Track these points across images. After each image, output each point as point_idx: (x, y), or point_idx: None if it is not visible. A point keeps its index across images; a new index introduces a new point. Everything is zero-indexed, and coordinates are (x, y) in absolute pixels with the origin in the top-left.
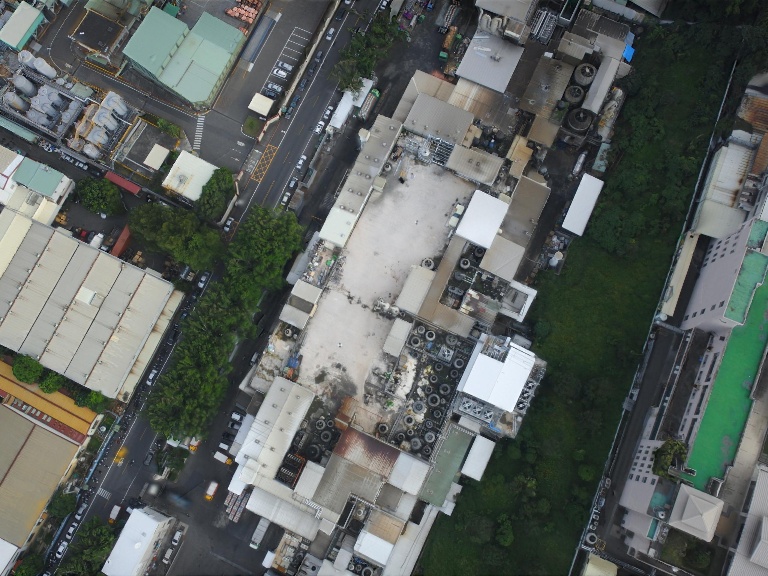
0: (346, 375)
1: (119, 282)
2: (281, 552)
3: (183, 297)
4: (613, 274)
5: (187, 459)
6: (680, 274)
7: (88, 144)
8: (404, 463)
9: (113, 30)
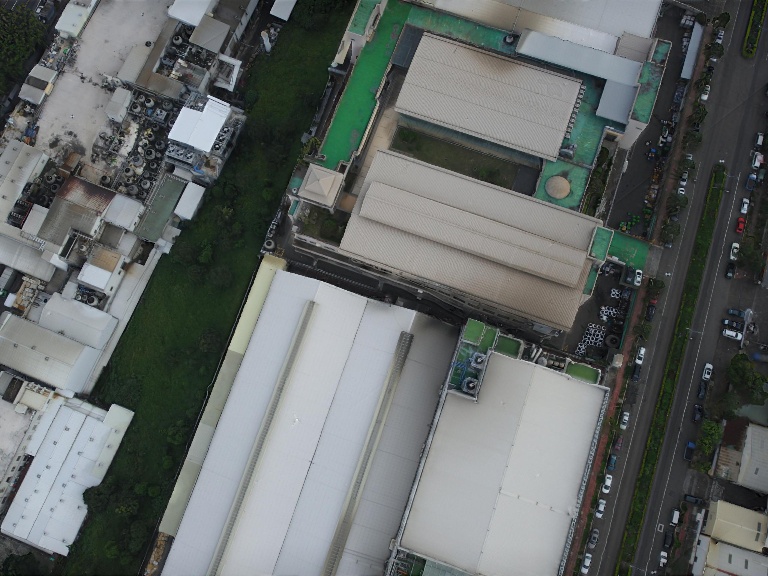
0: (77, 140)
1: None
2: (21, 293)
3: None
4: (308, 45)
5: None
6: None
7: None
8: (118, 202)
9: None
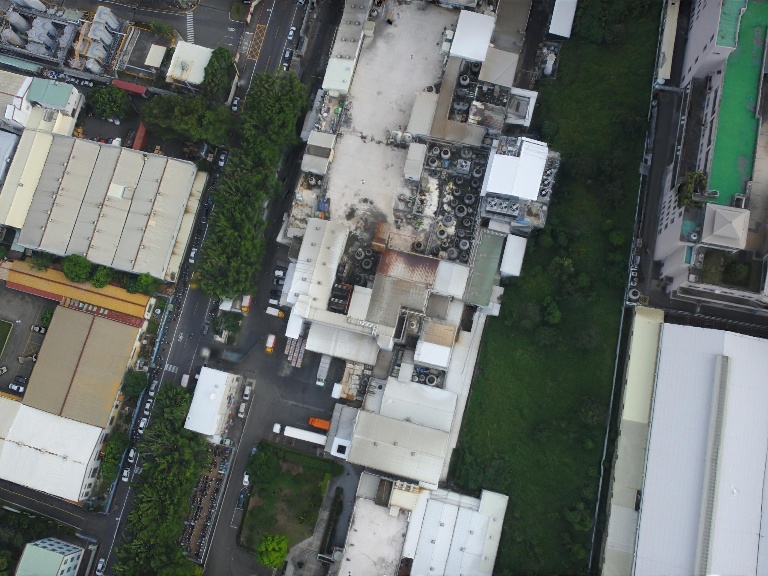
0: (374, 207)
1: (145, 173)
2: (347, 382)
3: (207, 178)
4: (606, 62)
5: (242, 322)
6: (669, 40)
7: (89, 59)
8: (445, 269)
9: None
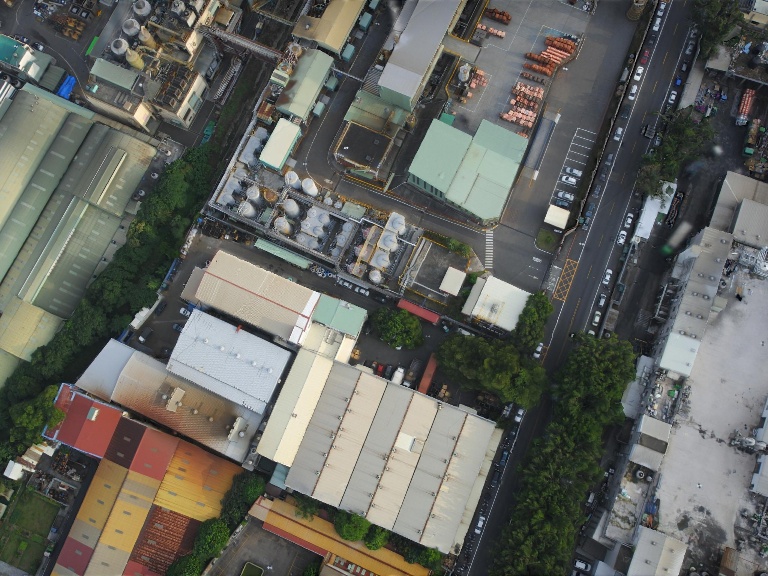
0: (711, 519)
1: (438, 424)
2: None
3: (501, 434)
4: None
5: None
6: None
7: (374, 270)
8: None
9: (380, 143)
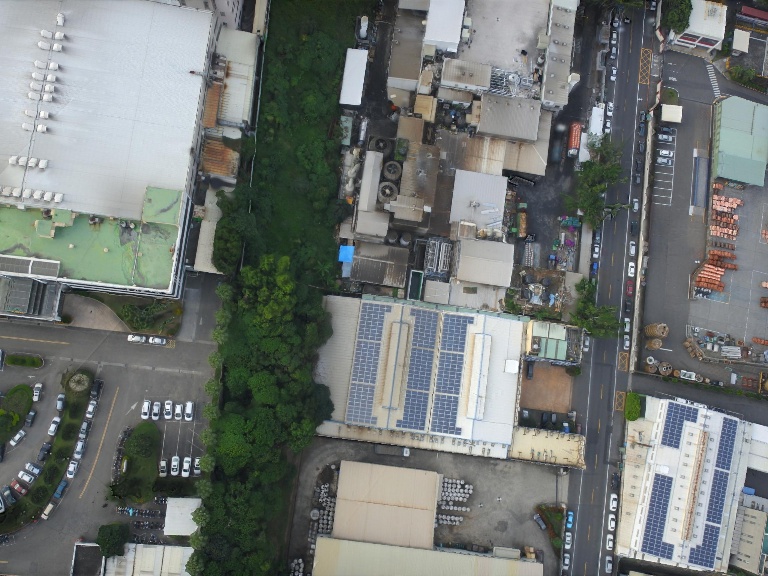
0: None
1: None
2: None
3: None
4: (314, 10)
5: None
6: None
7: None
8: None
9: None
